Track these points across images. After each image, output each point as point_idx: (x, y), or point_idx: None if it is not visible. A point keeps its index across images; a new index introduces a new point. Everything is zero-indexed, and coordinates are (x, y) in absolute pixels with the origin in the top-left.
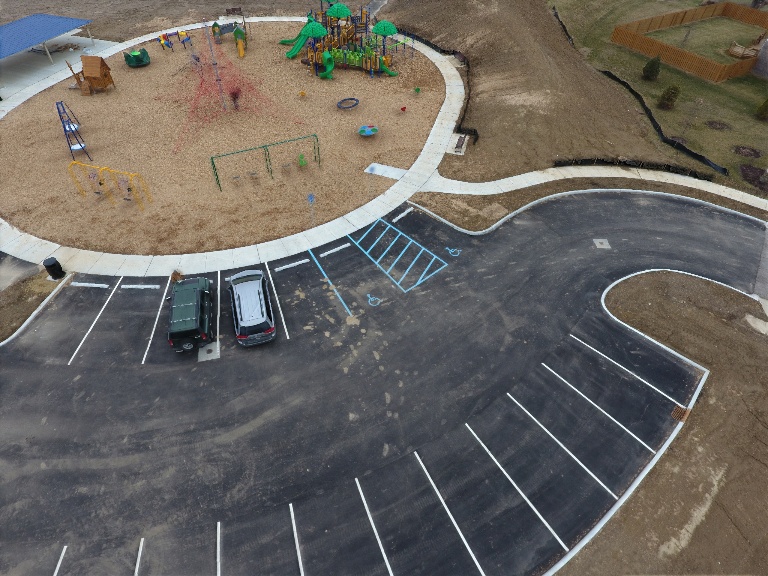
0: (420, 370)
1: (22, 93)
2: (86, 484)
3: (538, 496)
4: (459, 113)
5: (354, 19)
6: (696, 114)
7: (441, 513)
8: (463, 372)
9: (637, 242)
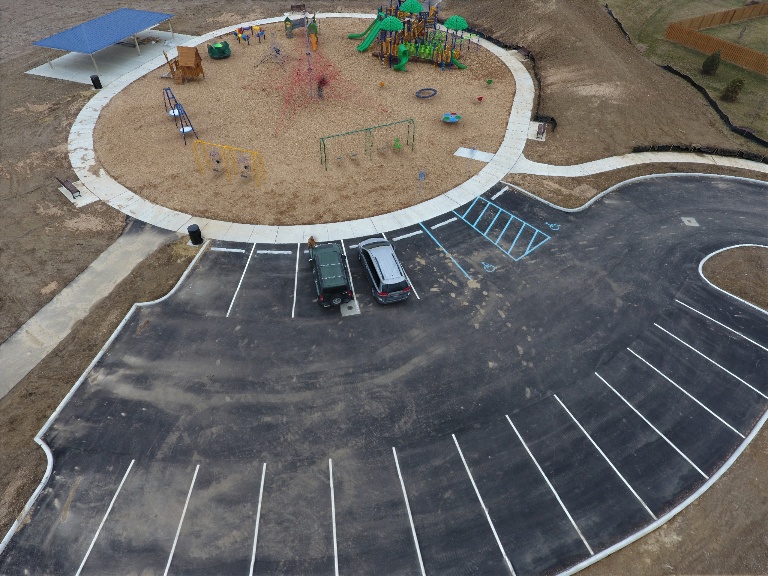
0: (544, 327)
1: (119, 81)
2: (269, 414)
3: (673, 433)
4: (532, 103)
5: (422, 15)
6: (759, 106)
7: (589, 445)
8: (584, 329)
9: (723, 221)
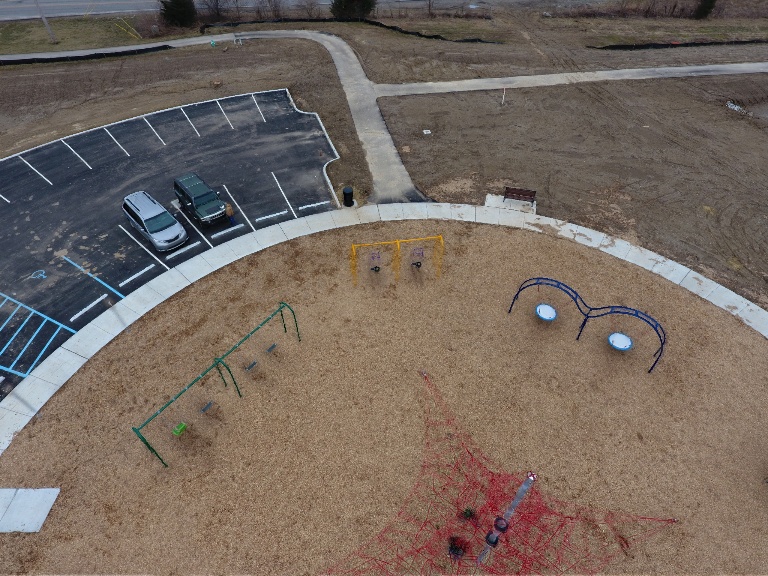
0: None
1: None
2: (208, 147)
3: None
4: None
5: None
6: None
7: None
8: None
9: None
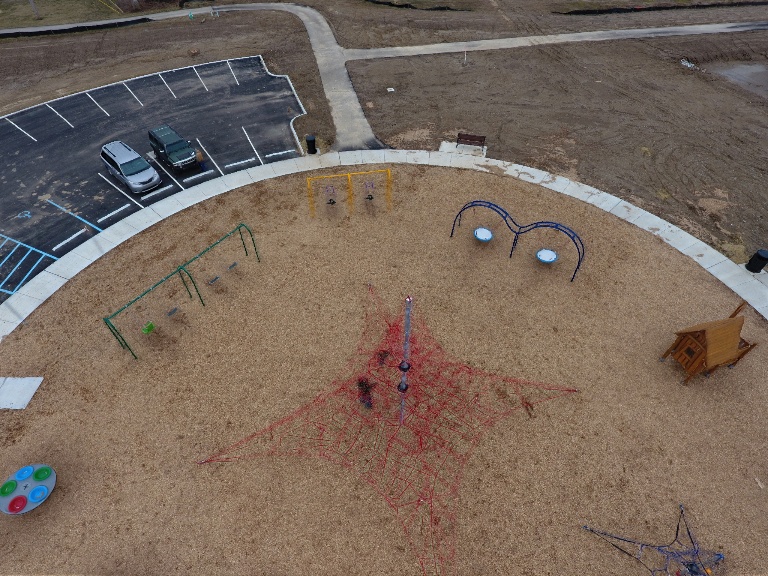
0: None
1: None
2: (184, 107)
3: None
4: None
5: None
6: None
7: None
8: None
9: None
